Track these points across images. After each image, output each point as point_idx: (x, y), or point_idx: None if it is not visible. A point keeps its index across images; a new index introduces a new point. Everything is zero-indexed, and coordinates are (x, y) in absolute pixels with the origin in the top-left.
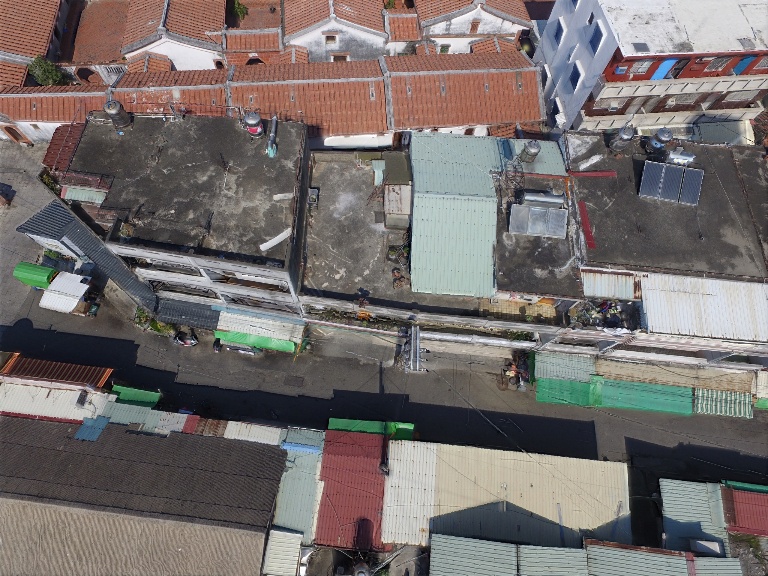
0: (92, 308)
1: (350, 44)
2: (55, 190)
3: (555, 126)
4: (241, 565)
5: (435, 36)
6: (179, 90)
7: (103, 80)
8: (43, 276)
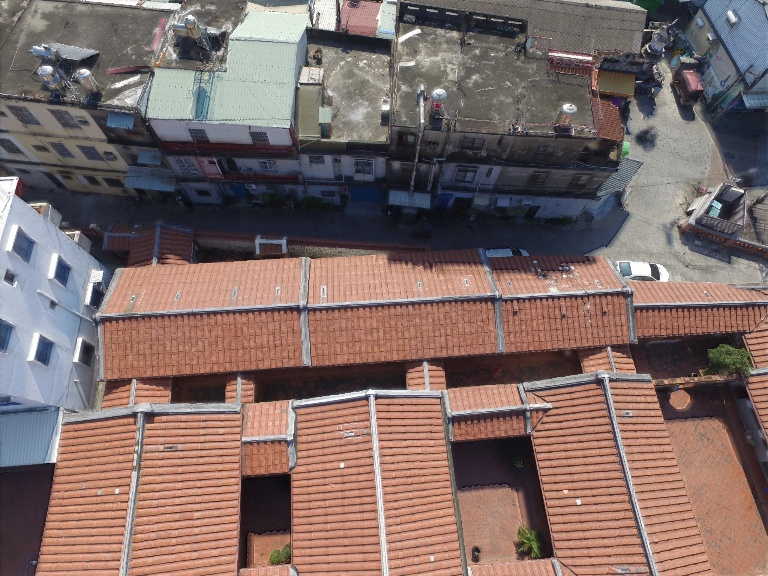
0: None
1: None
2: None
3: (103, 291)
4: None
5: None
6: None
7: None
8: None
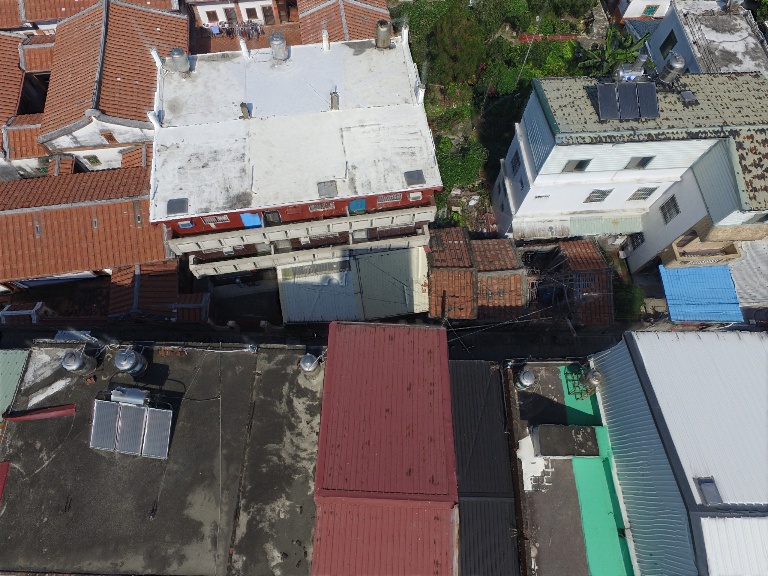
0: None
1: None
2: None
3: None
4: None
5: (66, 150)
6: None
7: None
8: None
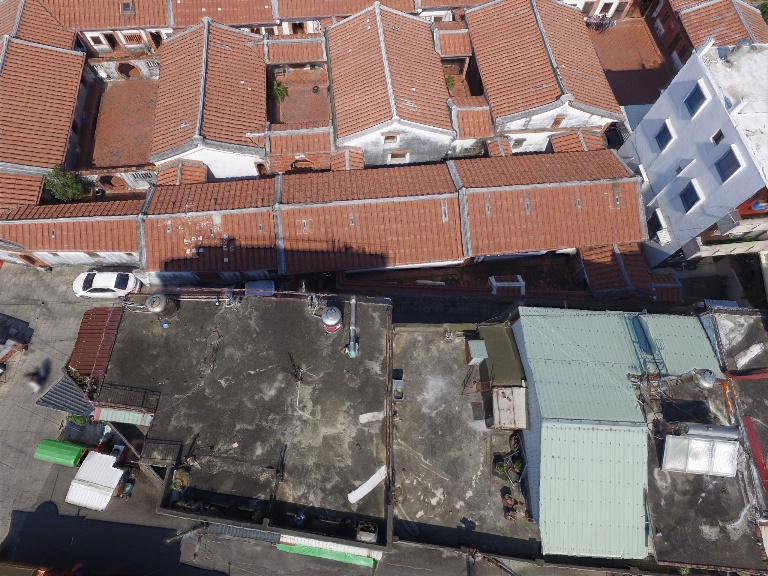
0: (126, 487)
1: (412, 142)
2: (85, 387)
3: (653, 239)
4: None
5: (510, 132)
6: (220, 215)
7: (129, 185)
8: (69, 460)
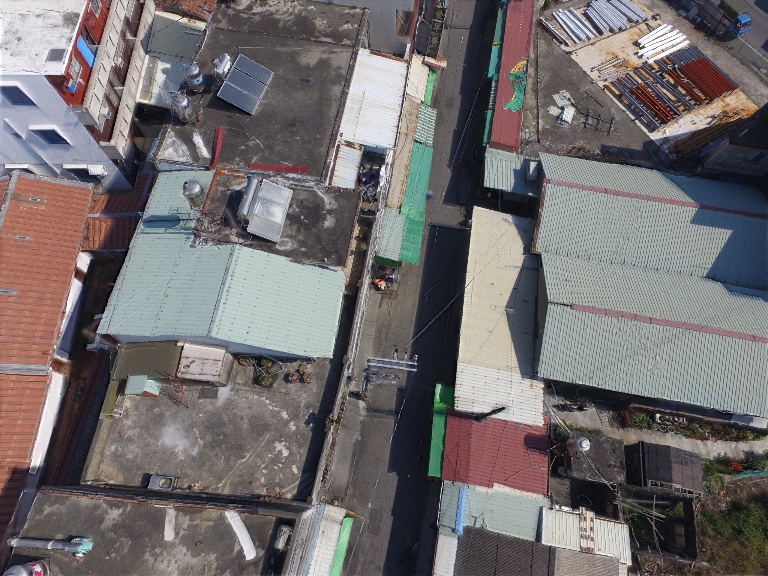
0: None
1: None
2: None
3: (100, 179)
4: (582, 575)
5: None
6: None
7: None
8: None
